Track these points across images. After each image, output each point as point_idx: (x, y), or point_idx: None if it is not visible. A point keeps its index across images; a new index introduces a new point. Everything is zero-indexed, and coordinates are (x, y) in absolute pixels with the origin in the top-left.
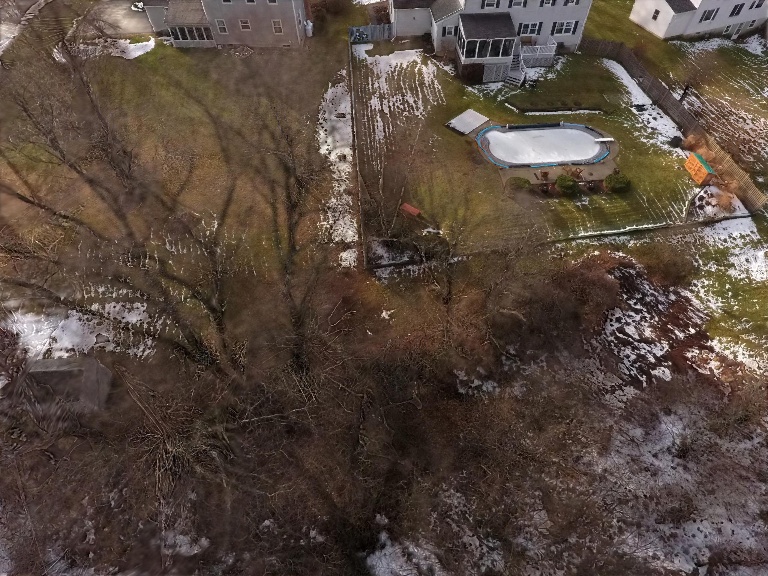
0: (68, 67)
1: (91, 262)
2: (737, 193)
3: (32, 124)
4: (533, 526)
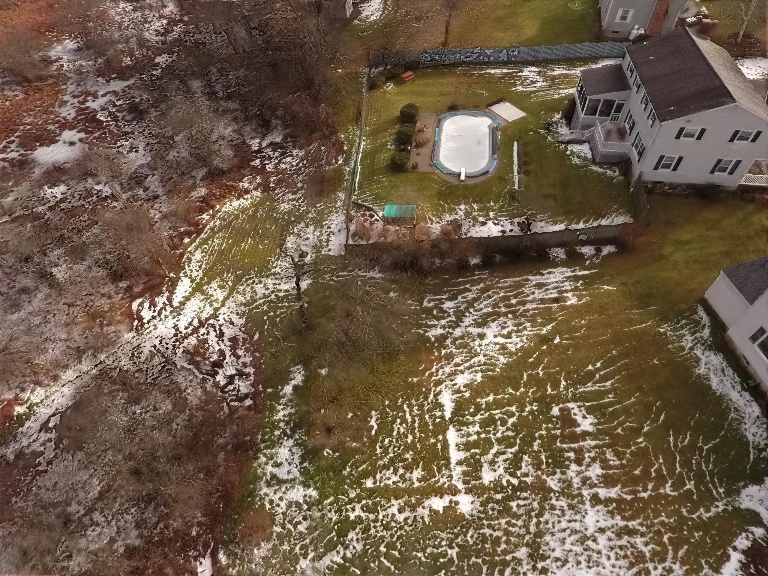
0: None
1: (405, 3)
2: None
3: None
4: None
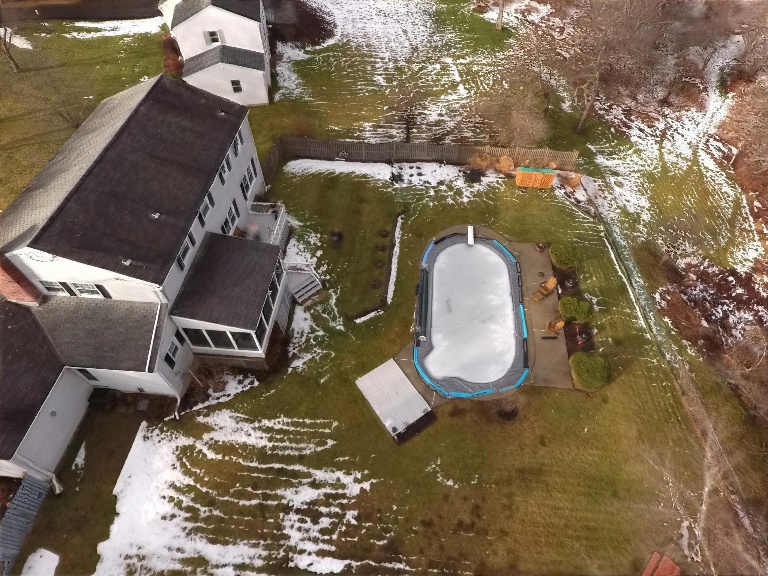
0: None
1: None
2: None
3: None
4: None
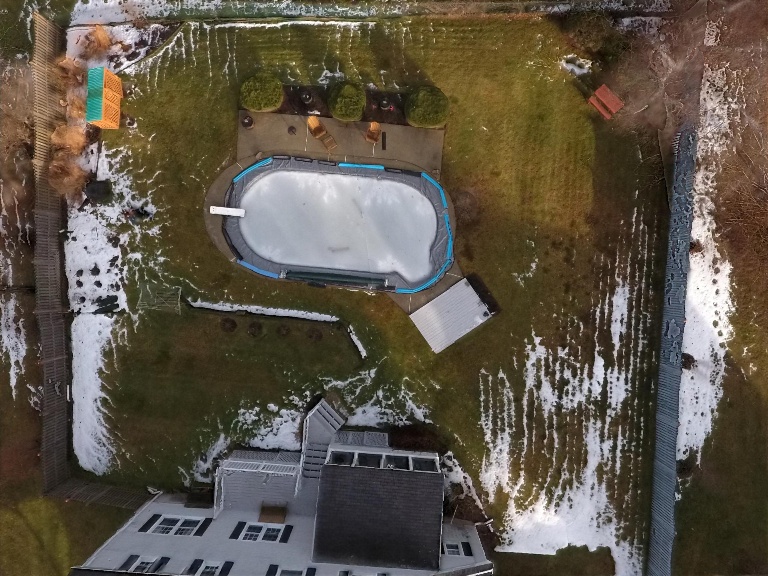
0: None
1: None
2: None
3: None
4: None
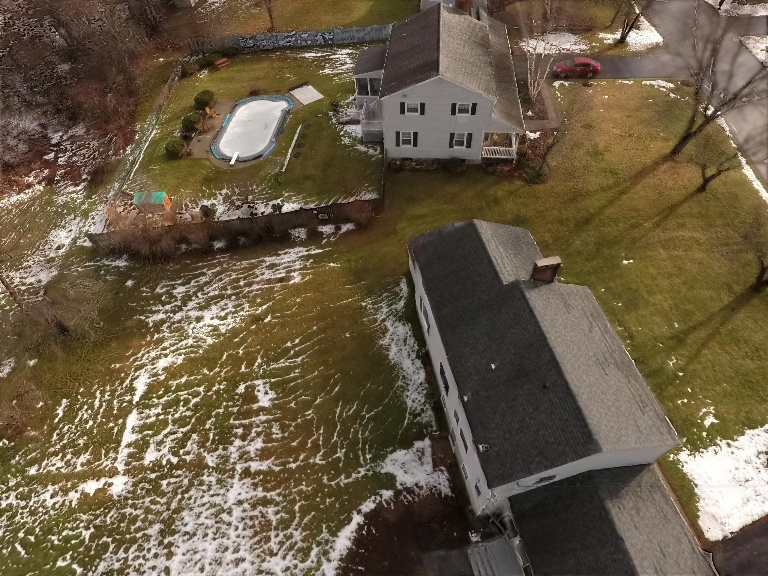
0: None
1: None
2: None
3: None
4: None
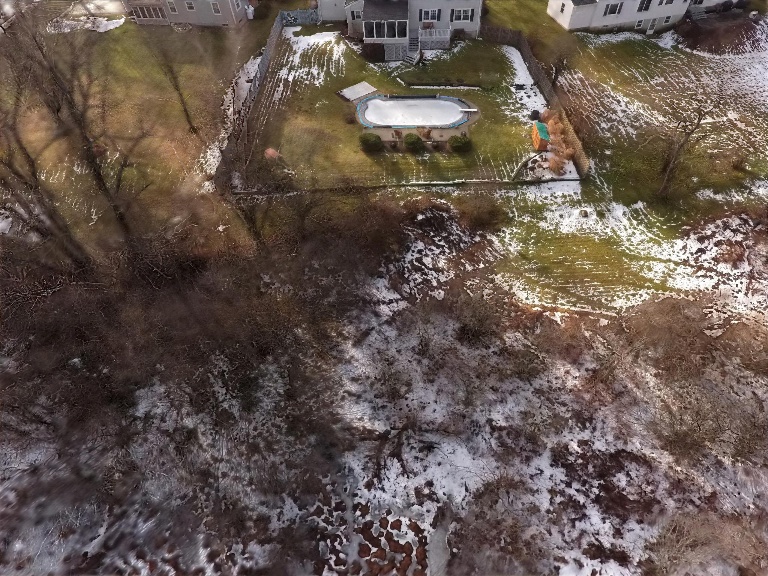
0: (54, 37)
1: None
2: (575, 161)
3: (13, 77)
4: (274, 387)
